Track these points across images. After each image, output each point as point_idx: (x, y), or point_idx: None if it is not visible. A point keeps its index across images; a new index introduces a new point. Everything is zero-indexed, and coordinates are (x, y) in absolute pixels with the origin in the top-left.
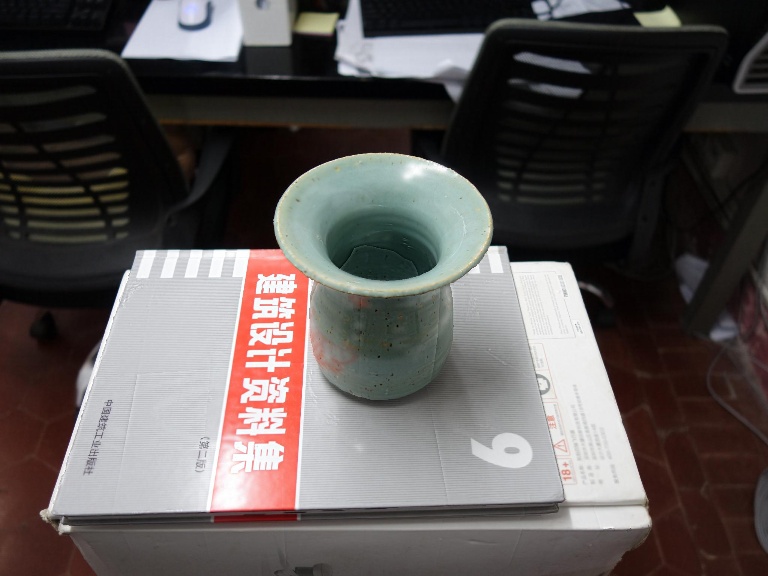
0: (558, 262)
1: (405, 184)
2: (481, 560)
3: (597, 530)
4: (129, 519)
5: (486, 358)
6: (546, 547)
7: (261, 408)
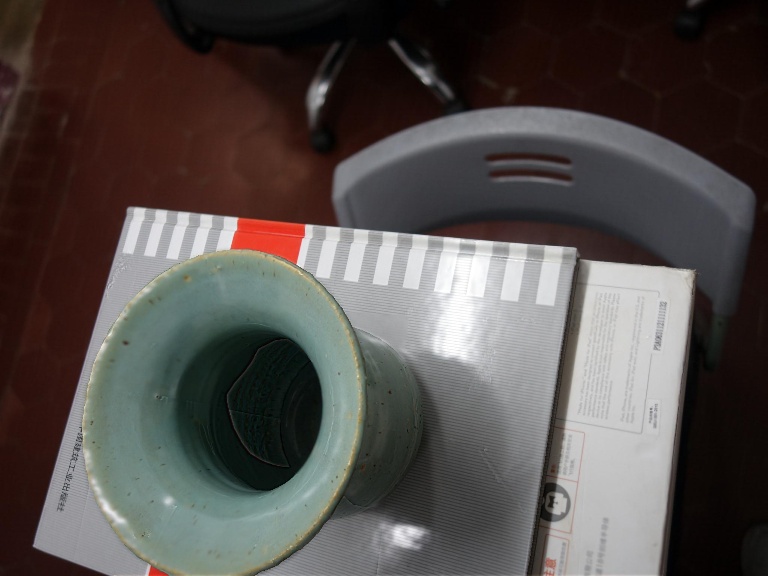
0: (674, 269)
1: (282, 309)
2: None
3: None
4: None
5: (476, 464)
6: None
7: None
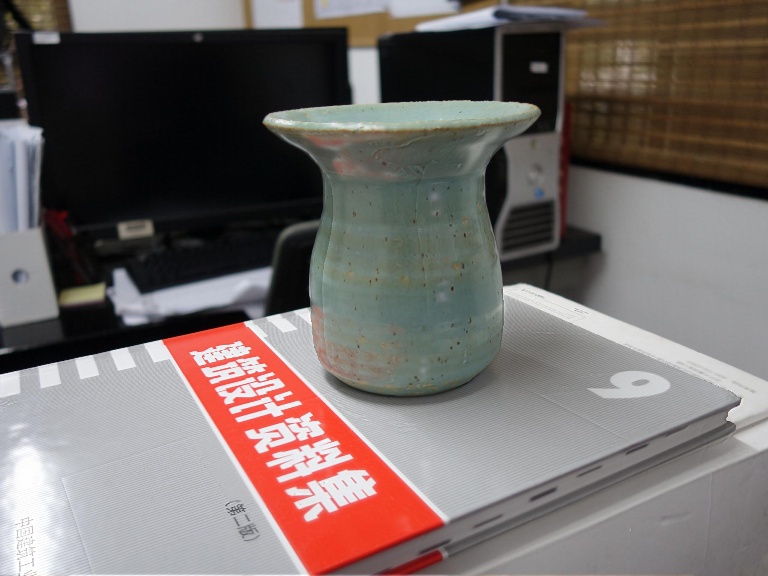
0: None
1: None
2: (676, 562)
3: None
4: None
5: (528, 335)
6: (737, 502)
7: (295, 448)
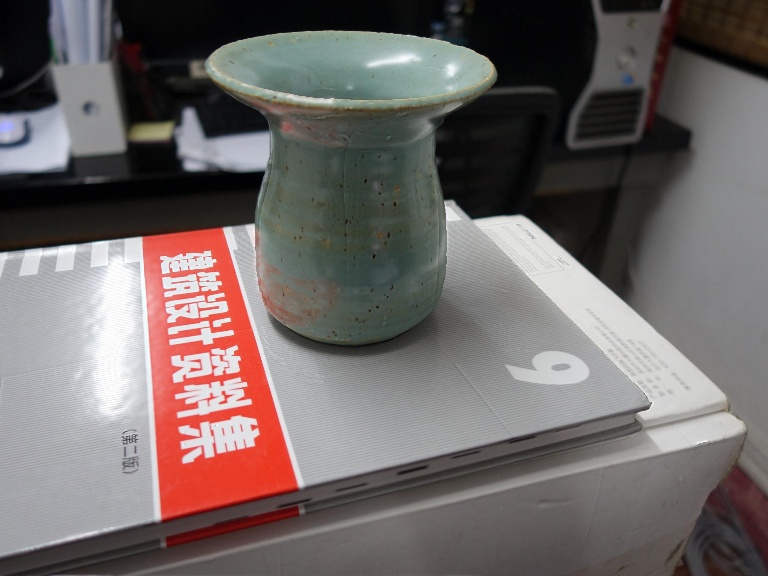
0: None
1: (358, 59)
2: (552, 538)
3: (690, 448)
4: (15, 574)
5: (482, 290)
6: (631, 494)
7: (207, 383)
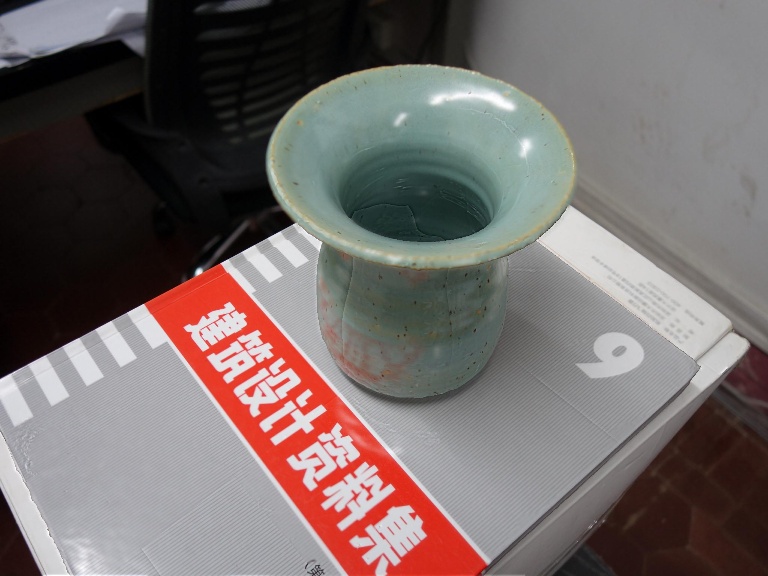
0: None
1: (385, 107)
2: (627, 479)
3: (718, 378)
4: None
5: (512, 275)
6: (677, 425)
7: (340, 480)
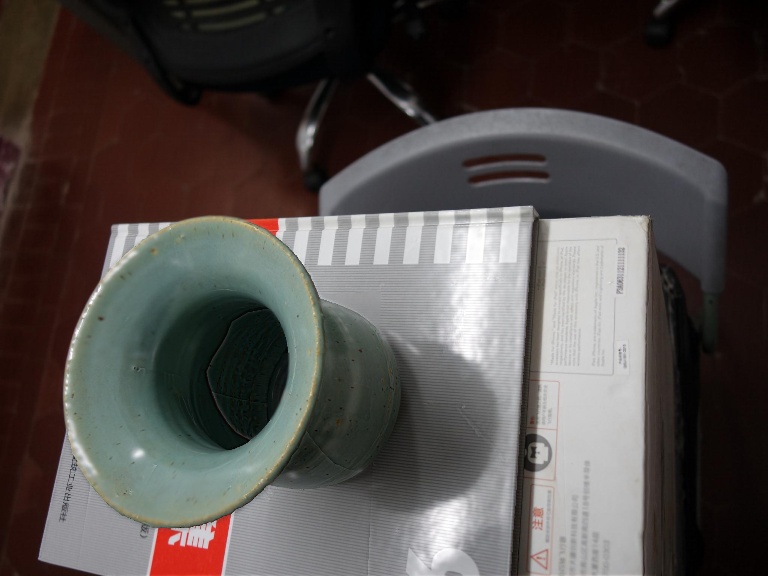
0: (629, 216)
1: (244, 268)
2: None
3: None
4: None
5: (456, 421)
6: None
7: None
